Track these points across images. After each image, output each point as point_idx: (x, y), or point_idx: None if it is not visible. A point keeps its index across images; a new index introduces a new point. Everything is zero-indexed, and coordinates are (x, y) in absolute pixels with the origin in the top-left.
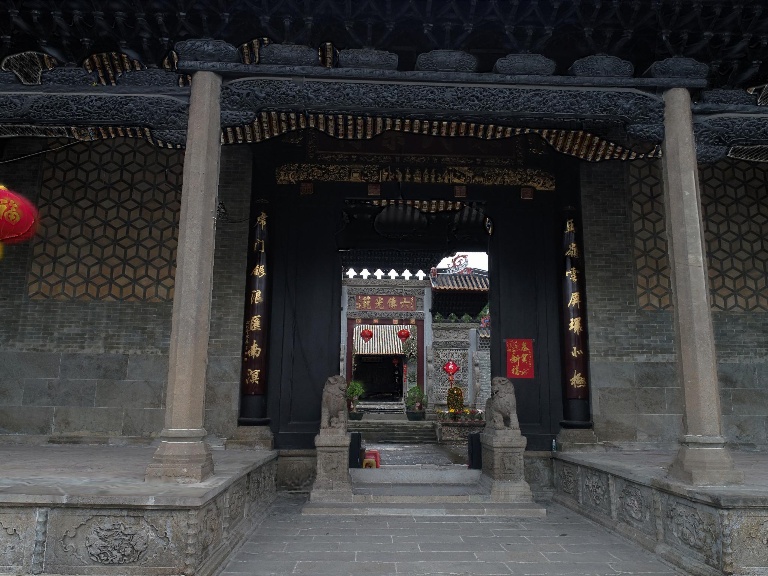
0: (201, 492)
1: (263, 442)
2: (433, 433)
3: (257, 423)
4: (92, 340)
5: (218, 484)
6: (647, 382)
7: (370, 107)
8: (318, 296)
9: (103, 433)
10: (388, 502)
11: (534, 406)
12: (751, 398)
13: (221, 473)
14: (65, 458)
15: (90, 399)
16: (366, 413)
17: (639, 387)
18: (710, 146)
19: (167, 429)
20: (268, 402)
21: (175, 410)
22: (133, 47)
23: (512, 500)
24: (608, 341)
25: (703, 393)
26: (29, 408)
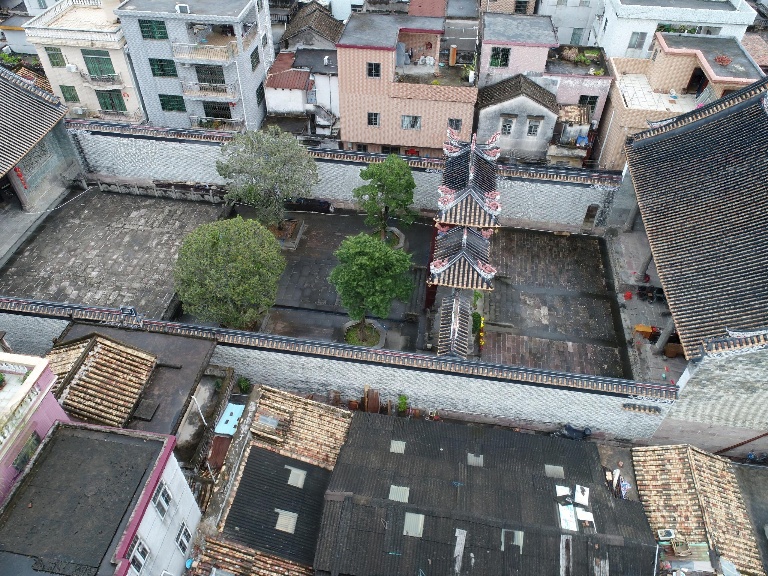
0: None
1: None
2: (499, 281)
3: None
4: None
5: None
6: None
7: None
8: None
9: None
10: None
11: None
12: None
13: None
14: None
15: None
16: None
17: None
18: None
19: None
20: None
21: None
22: None
23: None
24: None
25: None
26: None
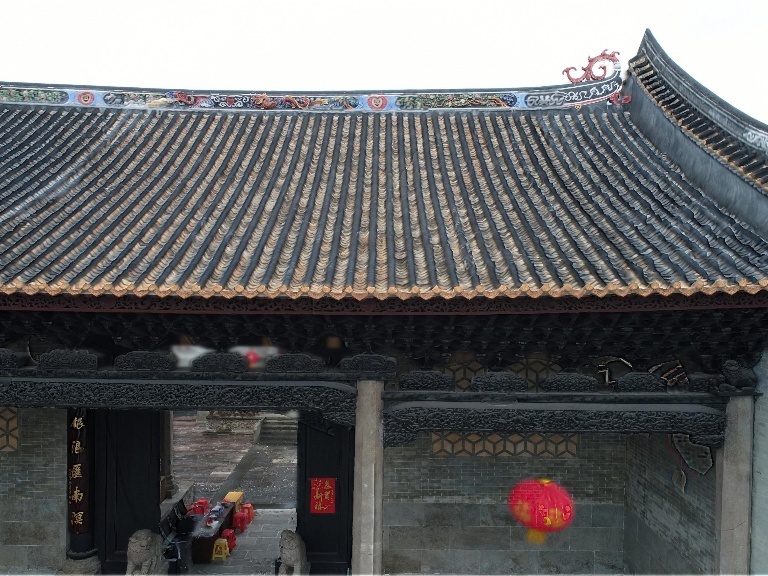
0: None
1: None
2: None
3: (83, 557)
4: None
5: None
6: (434, 521)
7: (75, 404)
8: (138, 439)
9: None
10: None
11: (334, 537)
12: (528, 535)
13: None
14: None
15: None
16: None
17: (426, 526)
18: (398, 433)
19: None
20: (95, 535)
21: None
22: None
23: None
24: (401, 484)
25: None
26: None
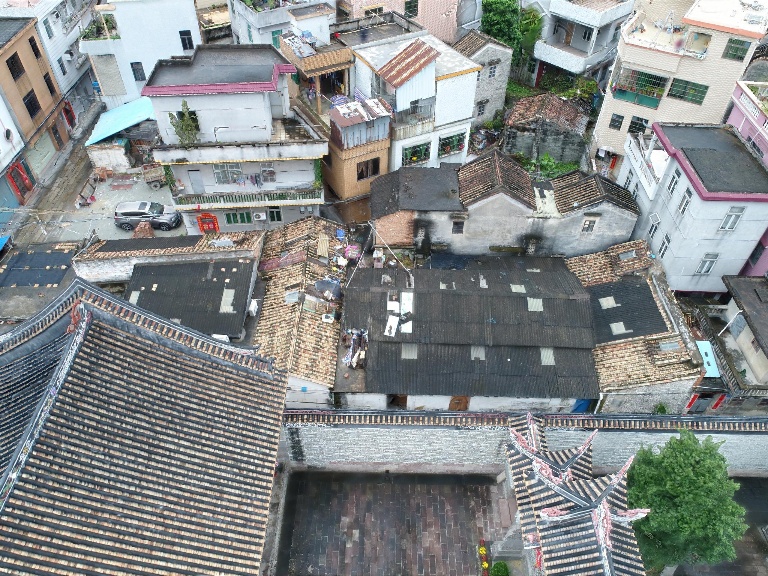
0: None
1: None
2: None
3: None
4: None
5: None
6: None
7: None
8: None
9: None
10: None
11: None
12: None
13: None
14: None
15: None
16: None
17: None
18: None
19: None
20: None
21: None
22: None
23: None
24: None
25: None
26: None
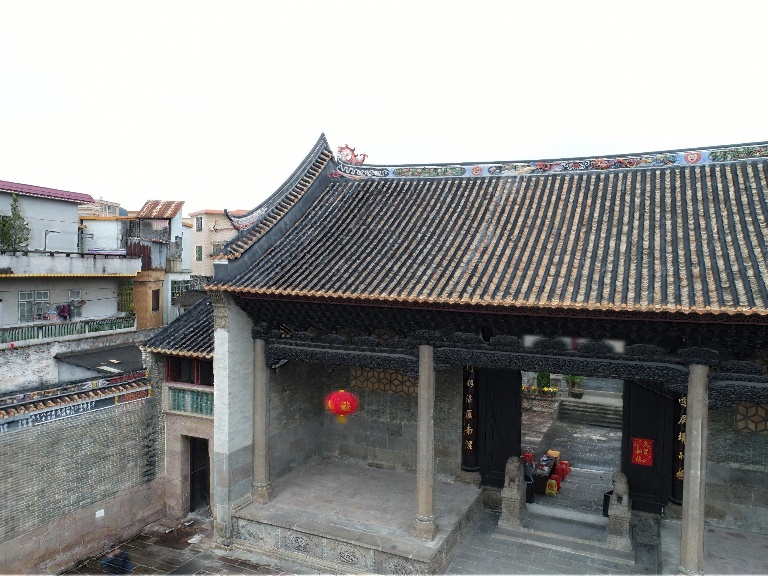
0: (430, 554)
1: (475, 483)
2: None
3: (472, 471)
4: (384, 414)
5: (439, 545)
6: (738, 482)
7: (508, 367)
8: (507, 398)
9: (393, 464)
10: (542, 535)
11: (651, 484)
12: None
13: (443, 530)
14: (377, 494)
15: (385, 445)
16: (588, 390)
17: (731, 485)
18: (719, 401)
19: (417, 515)
20: (478, 458)
21: (420, 508)
22: (392, 329)
23: (618, 548)
24: (709, 450)
25: (689, 548)
26: (357, 446)
